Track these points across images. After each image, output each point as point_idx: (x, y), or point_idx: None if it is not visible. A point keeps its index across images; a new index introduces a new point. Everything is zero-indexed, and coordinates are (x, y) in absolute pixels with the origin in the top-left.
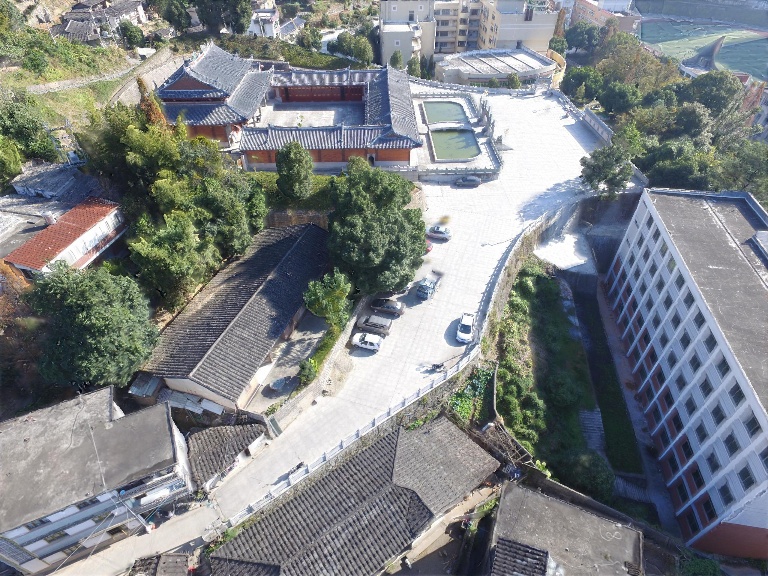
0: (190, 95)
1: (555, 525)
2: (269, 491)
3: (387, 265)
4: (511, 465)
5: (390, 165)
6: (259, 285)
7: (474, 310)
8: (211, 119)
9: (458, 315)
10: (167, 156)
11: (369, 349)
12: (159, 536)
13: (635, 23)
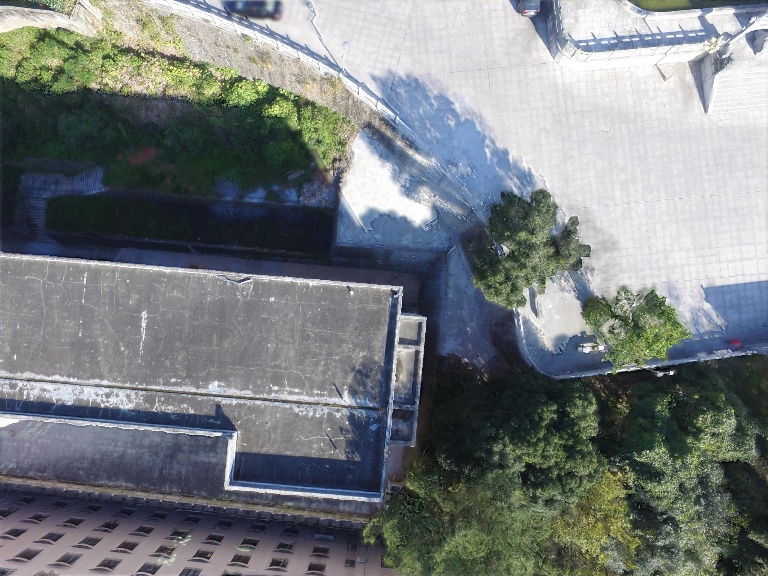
0: None
1: None
2: None
3: None
4: None
5: None
6: None
7: None
8: None
9: None
10: None
11: None
12: None
13: None
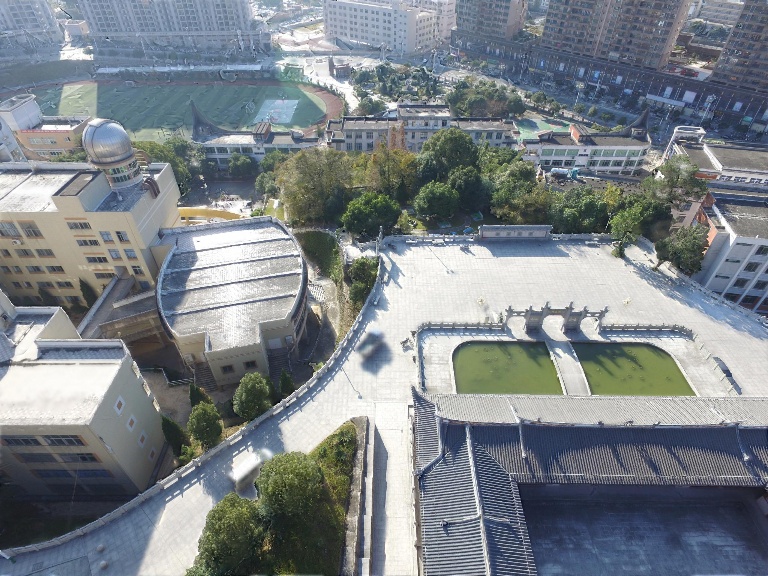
0: None
1: None
2: None
3: None
4: None
5: None
6: None
7: None
8: None
9: None
10: None
11: None
12: None
13: None
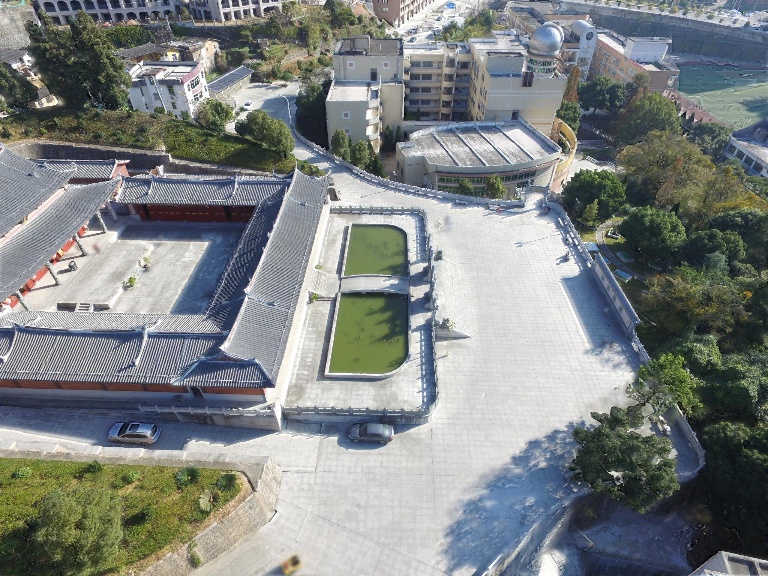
0: None
1: None
2: None
3: None
4: None
5: (231, 398)
6: None
7: None
8: None
9: None
10: None
11: None
12: None
13: (671, 79)
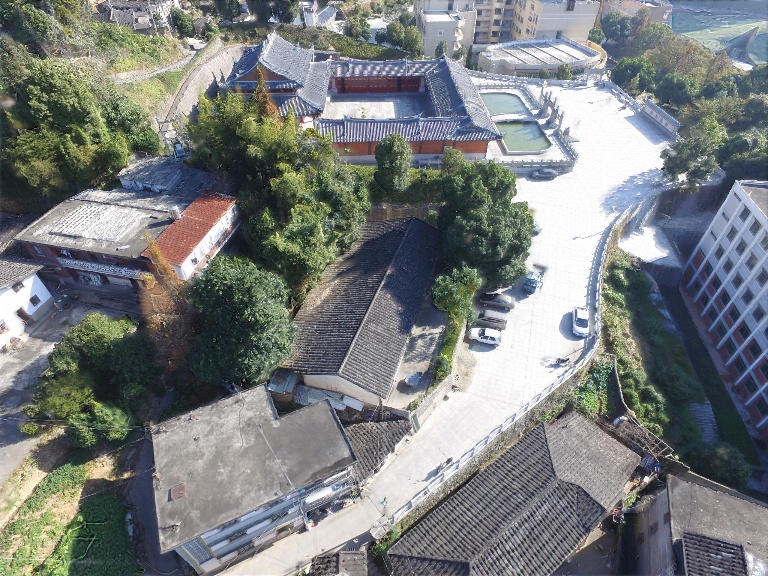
0: None
1: (730, 519)
2: (427, 487)
3: (508, 259)
4: (653, 459)
5: (466, 157)
6: (380, 280)
7: (583, 304)
8: (284, 111)
9: (568, 309)
10: (285, 149)
11: (489, 344)
12: (320, 534)
13: (666, 13)
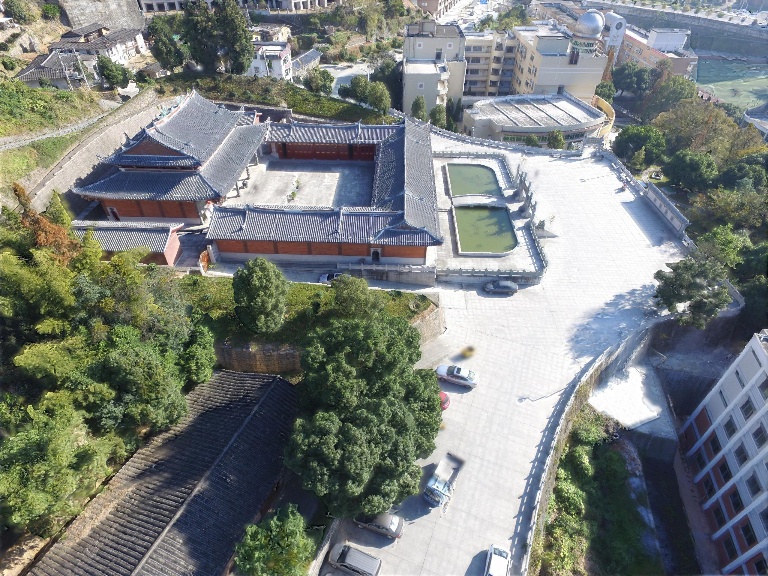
0: (153, 162)
1: None
2: None
3: (377, 487)
4: None
5: (400, 262)
6: (177, 508)
7: (508, 533)
8: (178, 192)
9: (483, 543)
10: (55, 299)
11: None
12: None
13: (690, 65)
